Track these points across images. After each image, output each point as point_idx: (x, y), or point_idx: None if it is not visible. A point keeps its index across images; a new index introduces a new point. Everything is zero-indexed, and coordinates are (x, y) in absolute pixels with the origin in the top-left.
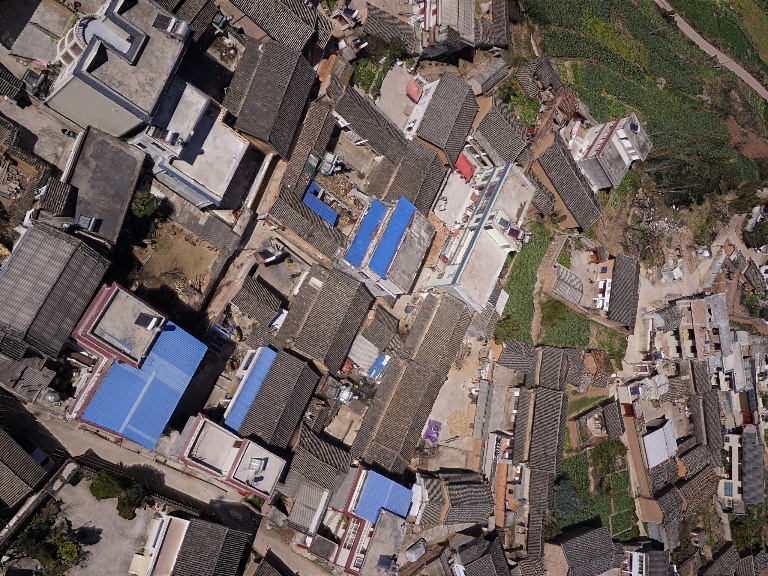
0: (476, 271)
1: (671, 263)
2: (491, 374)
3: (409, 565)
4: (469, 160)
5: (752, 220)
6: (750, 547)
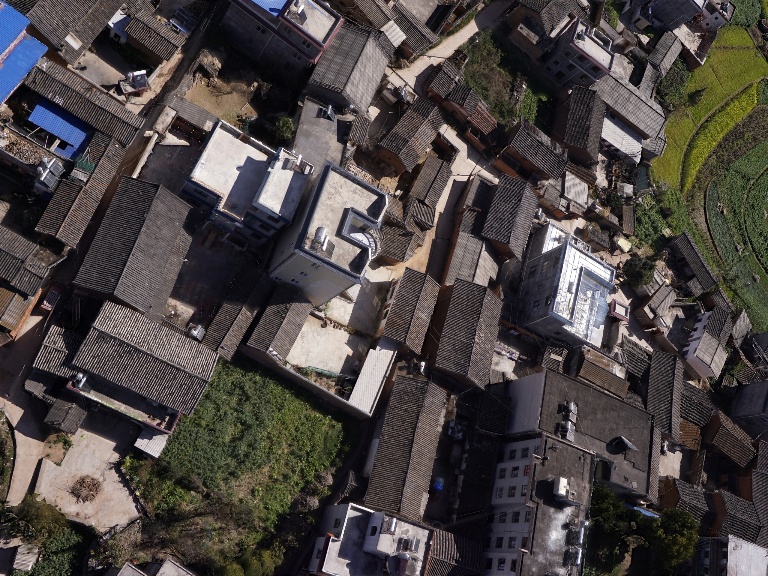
0: None
1: None
2: None
3: None
4: None
5: None
6: None
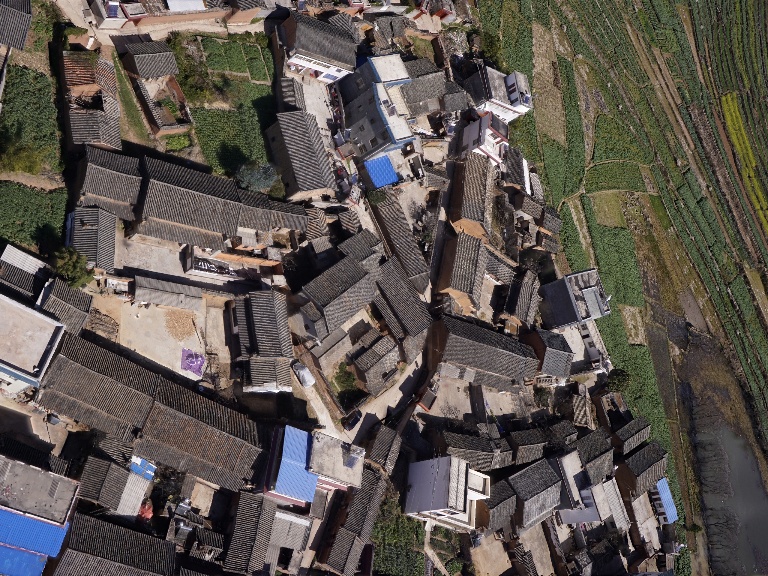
0: (5, 339)
1: None
2: None
3: None
4: None
5: None
6: None
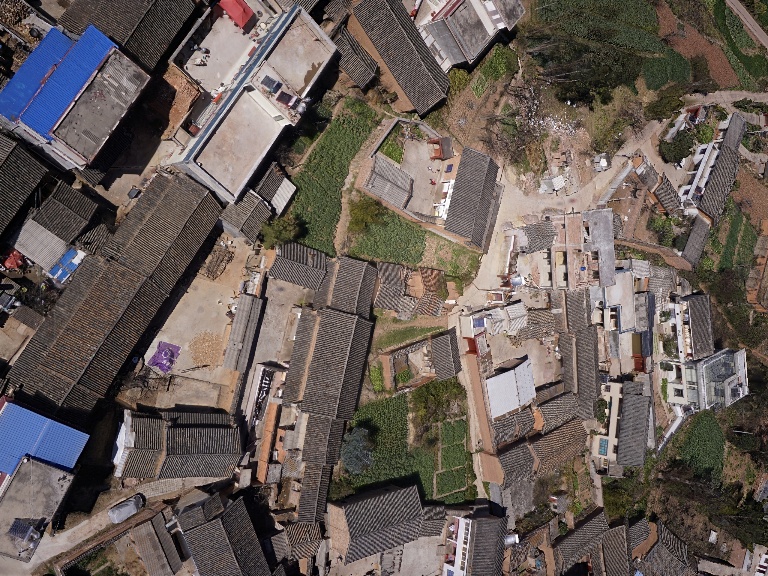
0: (229, 147)
1: (555, 171)
2: (259, 288)
3: (115, 527)
4: (249, 2)
5: (674, 129)
6: (624, 515)
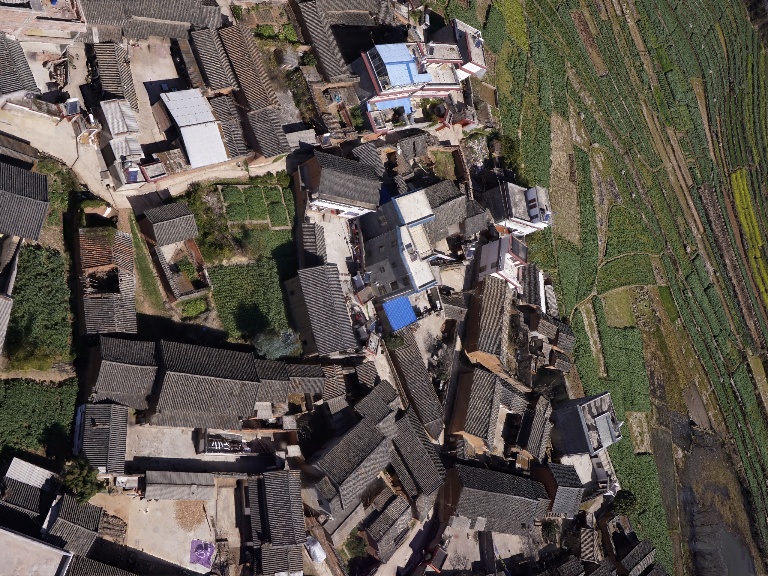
0: None
1: None
2: None
3: None
4: None
5: None
6: None
